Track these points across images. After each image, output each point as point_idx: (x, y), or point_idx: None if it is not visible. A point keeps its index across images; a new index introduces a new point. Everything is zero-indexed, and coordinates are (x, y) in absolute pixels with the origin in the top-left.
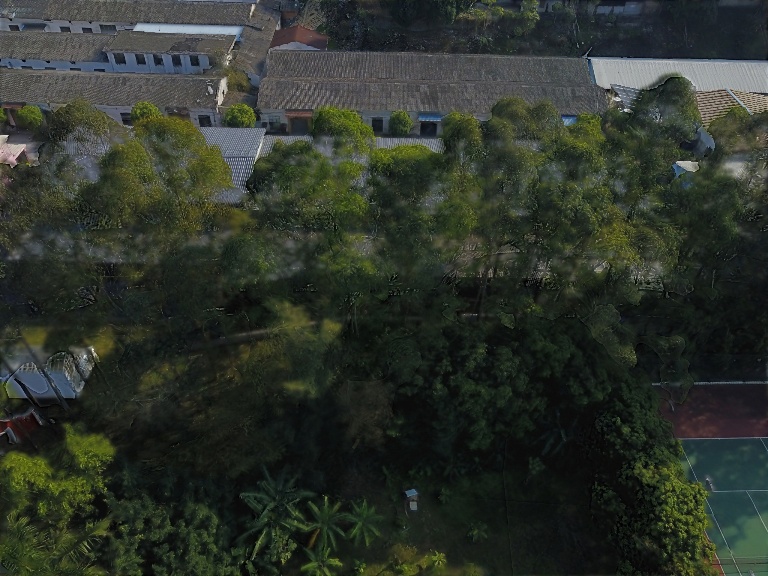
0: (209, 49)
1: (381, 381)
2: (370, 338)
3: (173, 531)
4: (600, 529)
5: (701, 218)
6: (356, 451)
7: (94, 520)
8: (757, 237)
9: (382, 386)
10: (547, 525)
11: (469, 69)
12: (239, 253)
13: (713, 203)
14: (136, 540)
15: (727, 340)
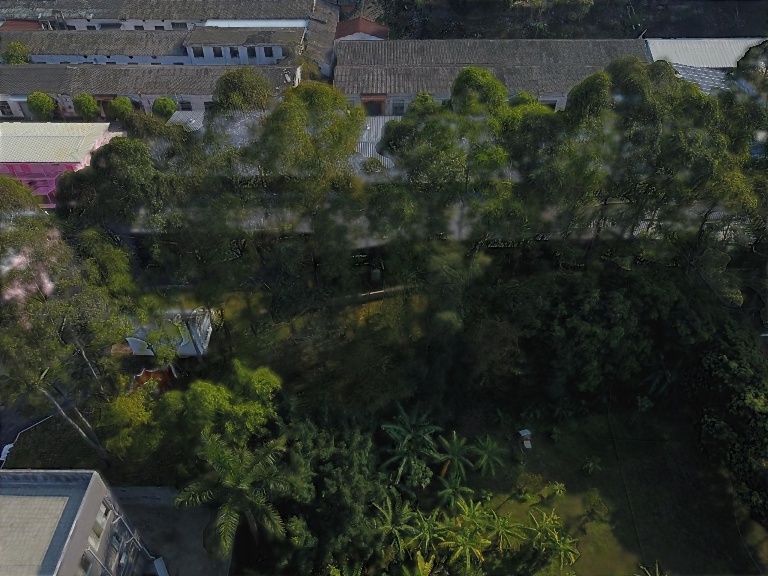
0: (282, 40)
1: (507, 321)
2: (483, 289)
3: (336, 451)
4: (710, 460)
5: None
6: (474, 393)
7: (269, 440)
8: None
9: (510, 325)
10: (655, 460)
11: (530, 52)
12: (386, 202)
13: None
14: (313, 454)
15: None
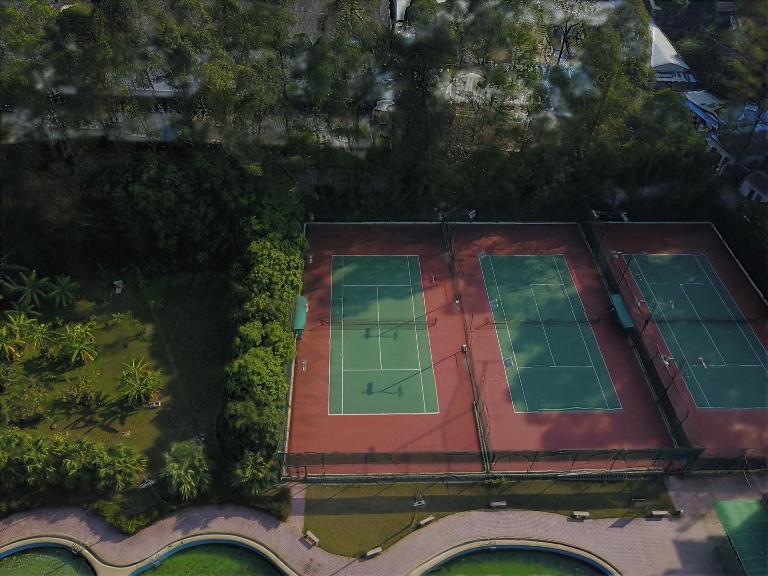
0: None
1: None
2: None
3: None
4: None
5: (309, 66)
6: (72, 248)
7: None
8: (365, 86)
9: (62, 180)
10: (214, 303)
11: None
12: None
13: (313, 53)
14: None
15: (396, 186)
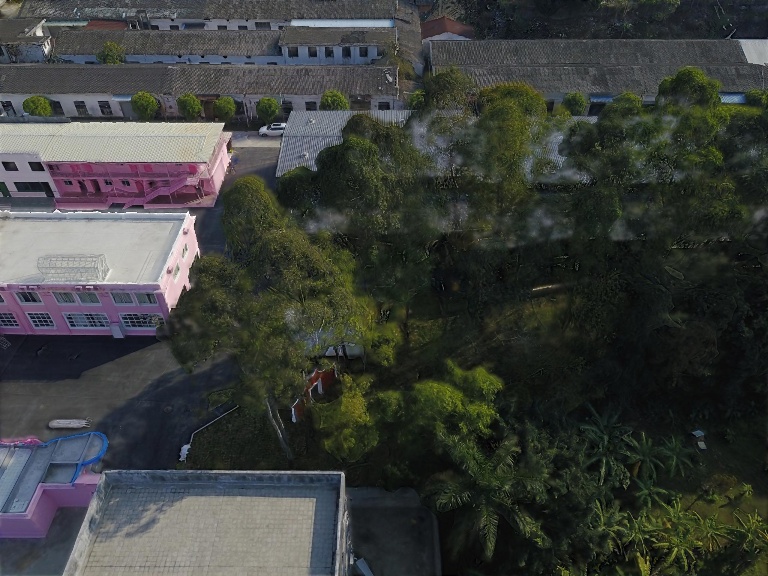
0: (377, 40)
1: (704, 322)
2: None
3: (558, 452)
4: None
5: None
6: (651, 394)
7: (495, 441)
8: None
9: (710, 326)
10: None
11: (625, 53)
12: (599, 203)
13: None
14: (549, 455)
15: None
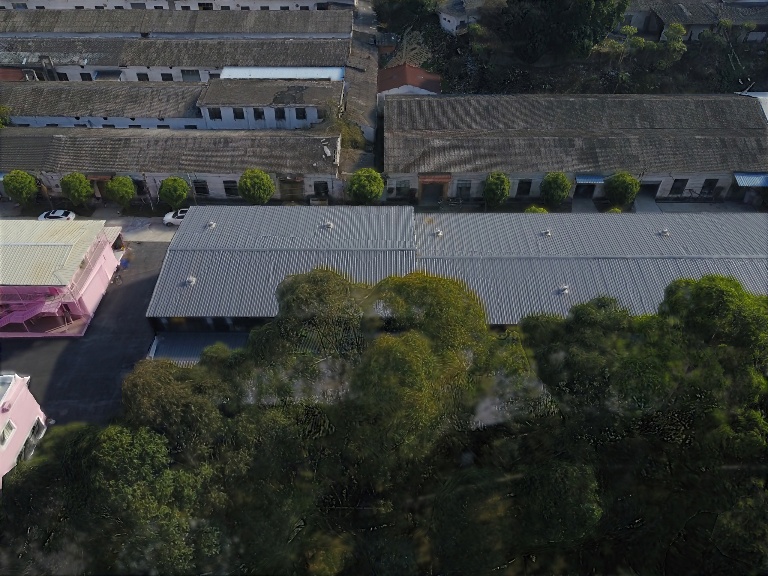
0: (317, 100)
1: None
2: None
3: None
4: None
5: None
6: None
7: None
8: None
9: None
10: None
11: (620, 115)
12: (563, 498)
13: None
14: None
15: None
